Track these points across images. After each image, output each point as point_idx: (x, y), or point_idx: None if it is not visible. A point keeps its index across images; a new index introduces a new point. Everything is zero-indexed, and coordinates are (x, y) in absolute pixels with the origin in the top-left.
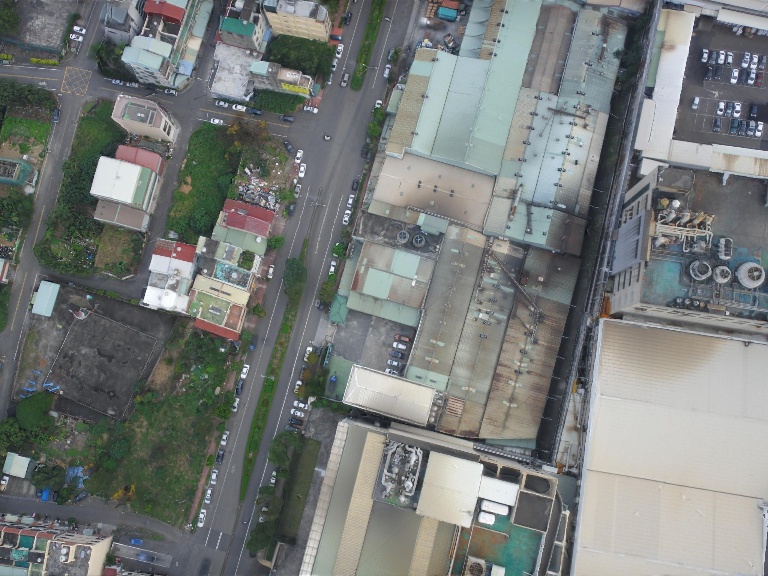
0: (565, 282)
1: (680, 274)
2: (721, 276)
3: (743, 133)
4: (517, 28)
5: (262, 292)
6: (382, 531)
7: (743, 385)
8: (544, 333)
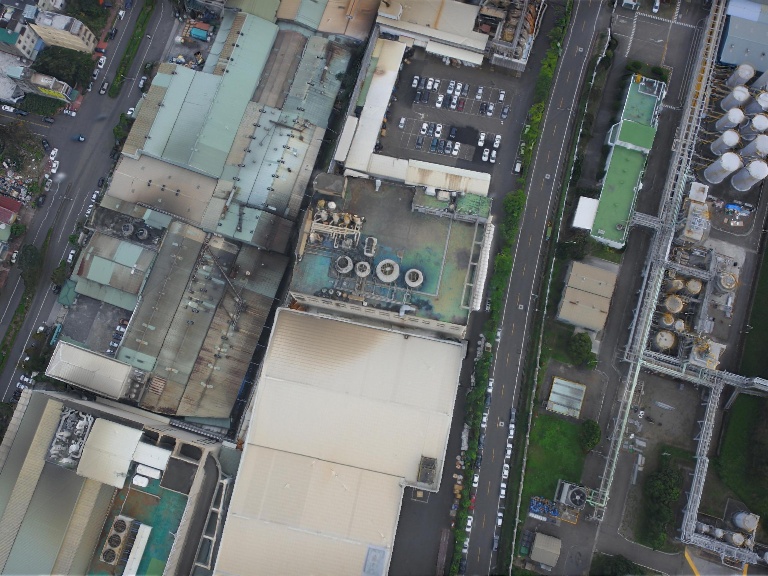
0: (271, 277)
1: (329, 267)
2: (359, 270)
3: (441, 151)
4: (250, 49)
5: (5, 275)
6: (48, 489)
7: (396, 373)
8: (246, 322)
